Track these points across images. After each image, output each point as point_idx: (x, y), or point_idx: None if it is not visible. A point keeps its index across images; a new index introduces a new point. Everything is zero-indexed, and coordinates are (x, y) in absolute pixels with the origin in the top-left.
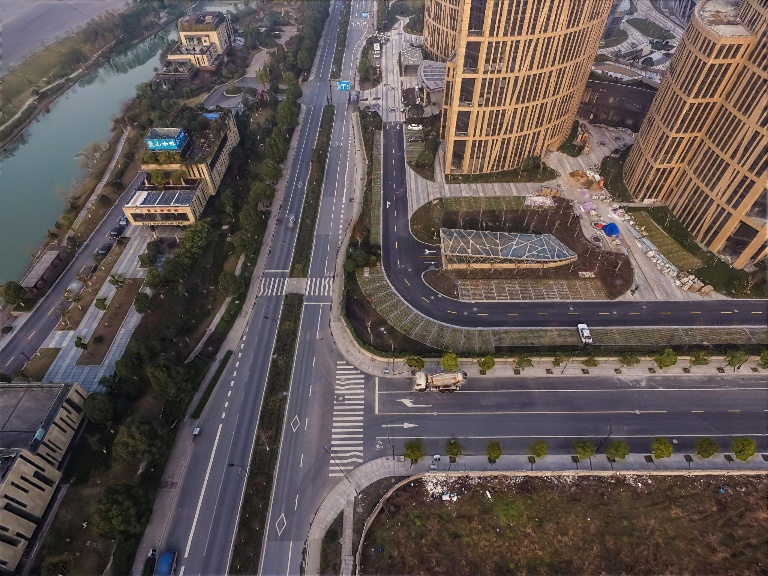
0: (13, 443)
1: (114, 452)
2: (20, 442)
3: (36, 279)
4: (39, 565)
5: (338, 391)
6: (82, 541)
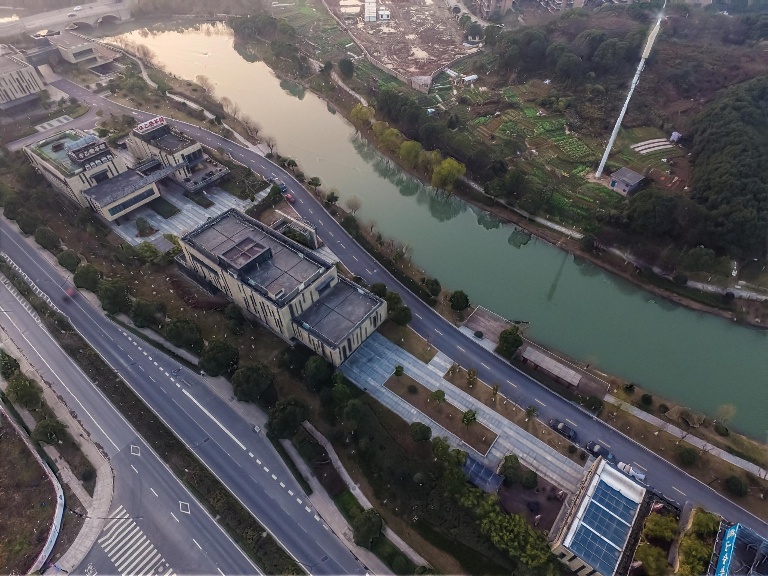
0: (317, 314)
1: (255, 361)
2: (314, 317)
3: (533, 360)
4: (254, 324)
5: (169, 573)
6: (246, 344)
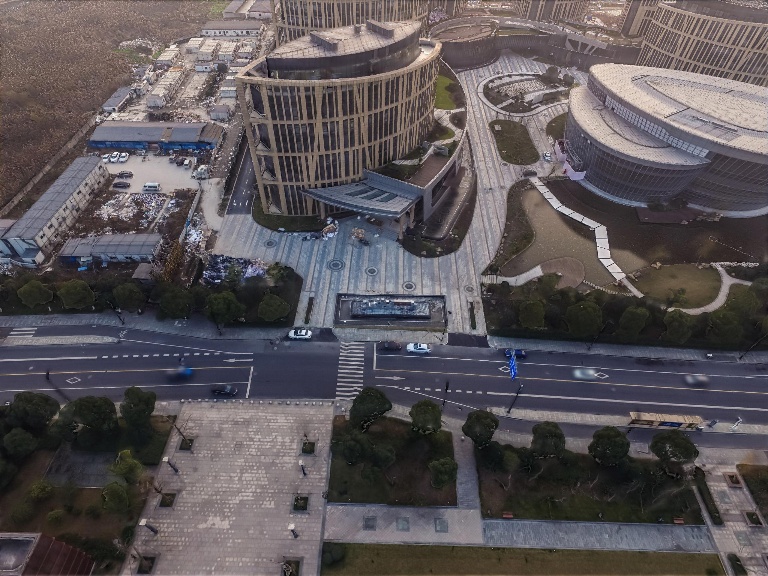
0: None
1: None
2: None
3: None
4: None
5: None
6: None
